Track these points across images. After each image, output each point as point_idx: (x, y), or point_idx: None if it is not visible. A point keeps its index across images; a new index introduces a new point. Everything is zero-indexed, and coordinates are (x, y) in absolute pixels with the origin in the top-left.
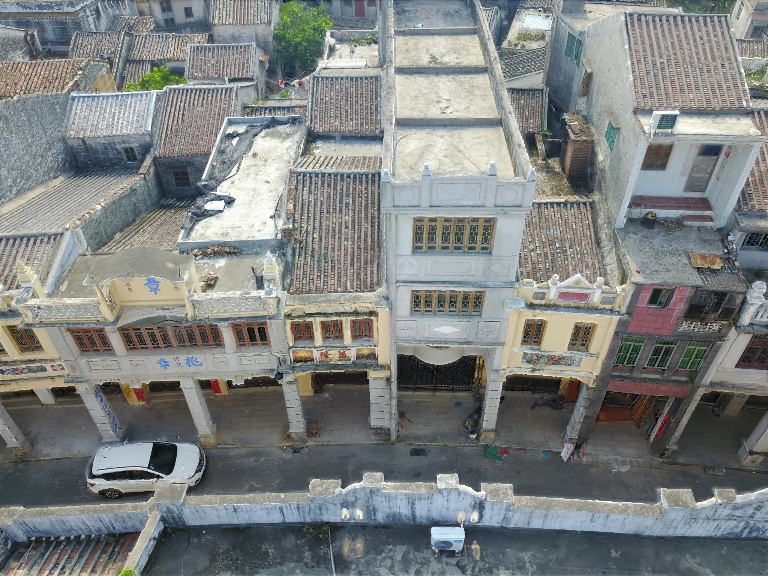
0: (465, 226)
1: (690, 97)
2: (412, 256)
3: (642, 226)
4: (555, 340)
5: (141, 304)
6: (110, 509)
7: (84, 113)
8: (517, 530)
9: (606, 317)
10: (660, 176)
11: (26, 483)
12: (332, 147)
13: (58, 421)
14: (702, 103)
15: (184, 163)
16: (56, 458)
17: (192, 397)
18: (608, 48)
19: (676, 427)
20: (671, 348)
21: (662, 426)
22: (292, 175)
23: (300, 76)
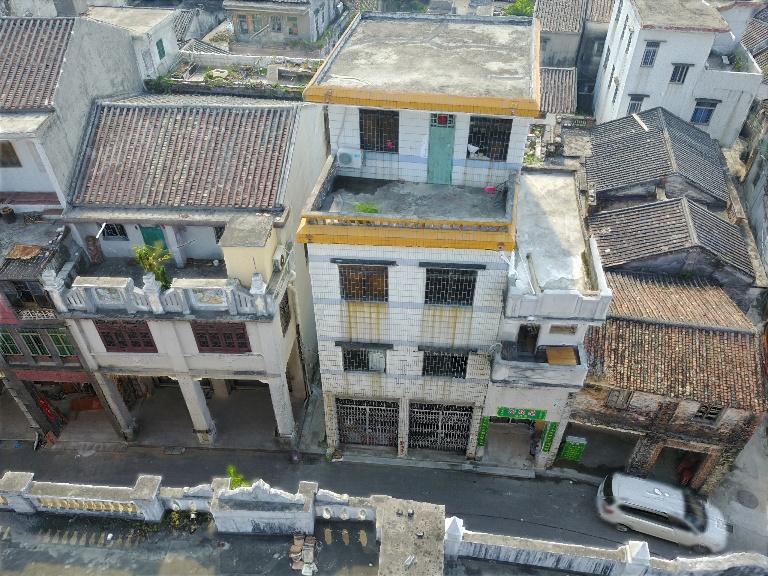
0: None
1: (1, 97)
2: None
3: (3, 221)
4: None
5: None
6: None
7: None
8: None
9: None
10: (22, 173)
11: None
12: None
13: None
14: (8, 103)
15: None
16: None
17: None
18: None
19: (111, 411)
20: (37, 336)
21: None
22: None
23: None
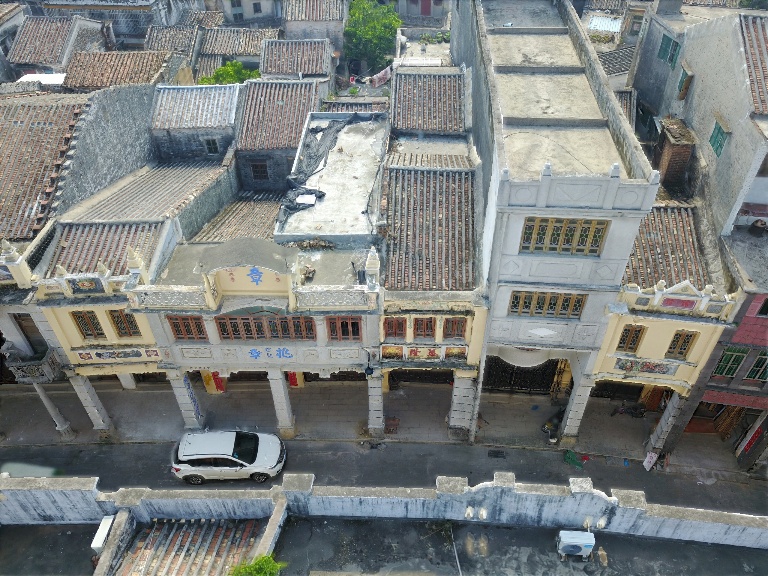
0: (576, 228)
1: None
2: (518, 256)
3: (750, 234)
4: (653, 347)
5: (242, 294)
6: (235, 495)
7: (169, 105)
8: (644, 538)
9: (710, 326)
10: None
11: (111, 465)
12: (415, 145)
13: (139, 406)
14: None
15: (264, 156)
16: (139, 442)
17: (278, 388)
18: (716, 51)
19: None
20: None
21: (753, 440)
22: (385, 171)
23: (366, 73)
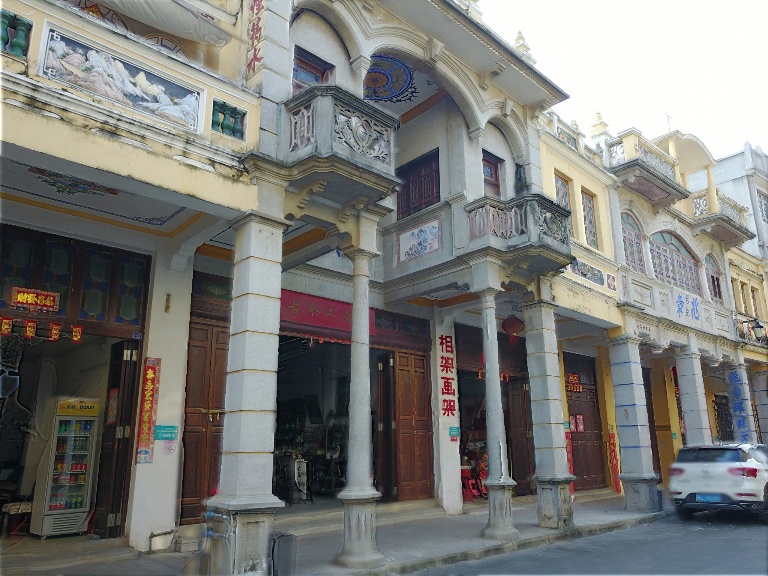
0: None
1: None
2: (763, 222)
3: None
4: None
5: None
6: None
7: None
8: None
9: None
10: None
11: (644, 540)
12: None
13: None
14: None
15: None
16: (607, 528)
17: (699, 378)
18: None
19: None
20: None
21: None
22: None
23: None
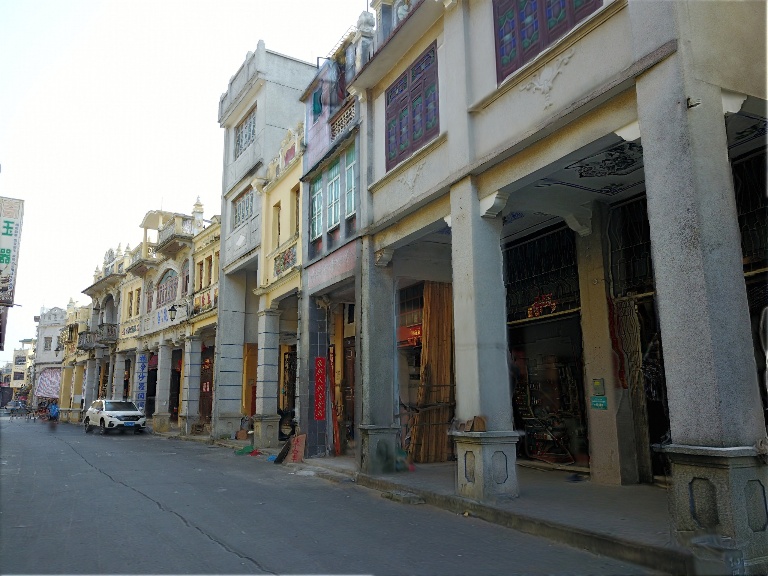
0: None
1: None
2: None
3: None
4: None
5: None
6: None
7: None
8: None
9: None
10: None
11: None
12: None
13: None
14: None
15: None
16: None
17: None
18: None
19: (361, 361)
20: None
21: None
22: None
23: None
